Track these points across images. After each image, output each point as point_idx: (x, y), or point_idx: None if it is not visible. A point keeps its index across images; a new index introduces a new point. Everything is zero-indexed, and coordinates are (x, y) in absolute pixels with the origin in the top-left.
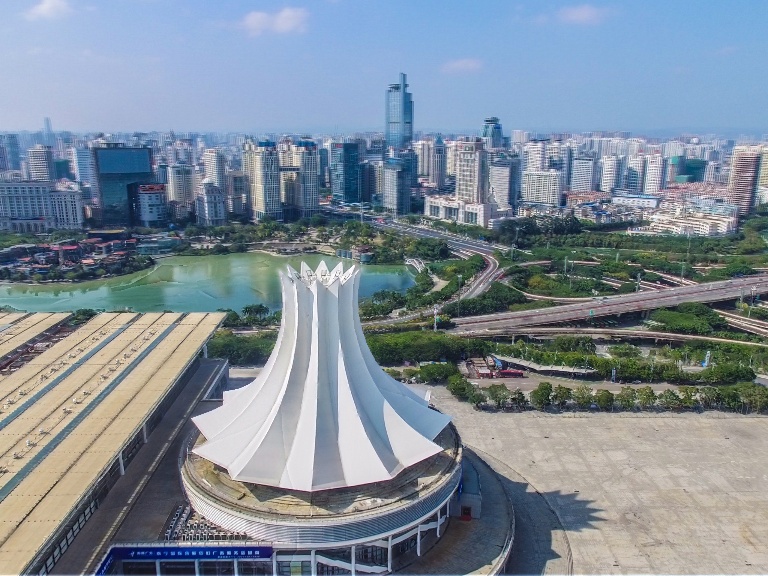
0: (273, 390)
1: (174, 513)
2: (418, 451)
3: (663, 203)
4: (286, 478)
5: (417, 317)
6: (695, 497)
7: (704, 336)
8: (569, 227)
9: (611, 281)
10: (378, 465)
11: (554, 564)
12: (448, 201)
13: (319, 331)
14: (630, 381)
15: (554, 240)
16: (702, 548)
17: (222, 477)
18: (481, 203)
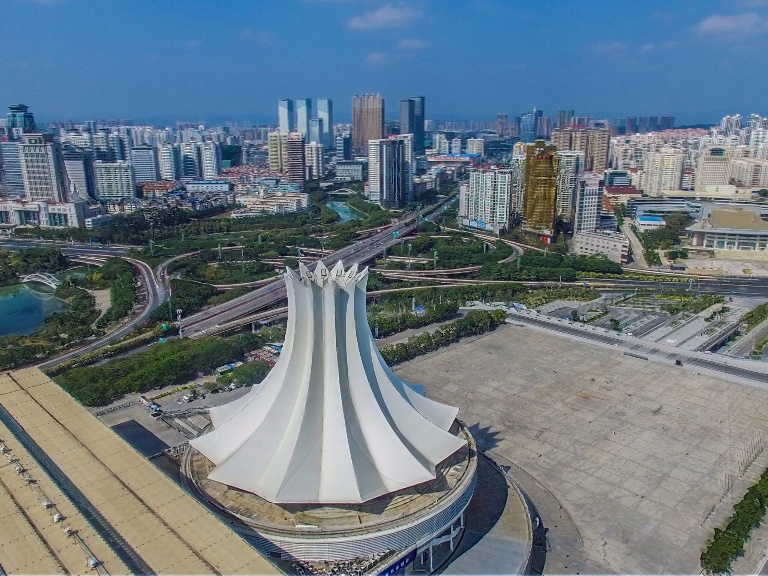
0: (316, 407)
1: (298, 574)
2: (445, 417)
3: (237, 186)
4: (391, 481)
5: (127, 332)
6: (522, 396)
7: (384, 290)
8: (178, 217)
9: (265, 261)
10: (448, 436)
11: (513, 473)
12: (21, 204)
13: (356, 331)
14: (388, 334)
15: (167, 232)
16: (562, 424)
17: (313, 515)
18: (65, 202)
